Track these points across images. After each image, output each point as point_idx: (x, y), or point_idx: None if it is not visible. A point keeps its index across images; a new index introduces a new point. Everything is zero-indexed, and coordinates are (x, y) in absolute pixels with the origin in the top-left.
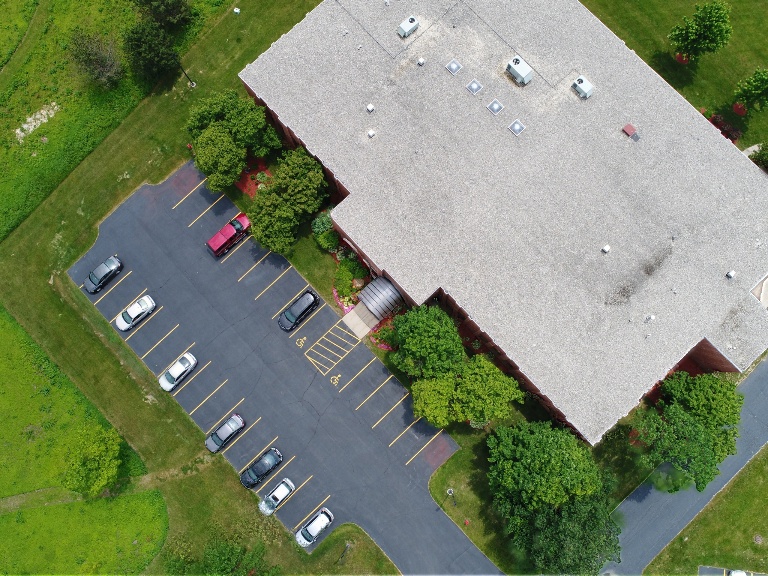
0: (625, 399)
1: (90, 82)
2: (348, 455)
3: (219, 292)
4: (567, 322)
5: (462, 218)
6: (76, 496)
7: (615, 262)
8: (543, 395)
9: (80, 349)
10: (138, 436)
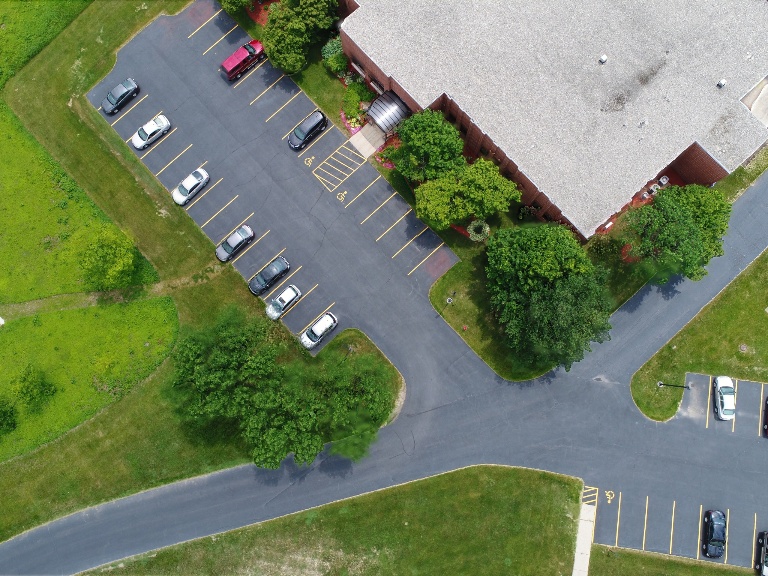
0: (618, 196)
1: None
2: (352, 266)
3: (231, 114)
4: (564, 126)
5: (466, 30)
6: (91, 302)
7: (611, 72)
8: (540, 193)
9: (97, 166)
10: (151, 247)
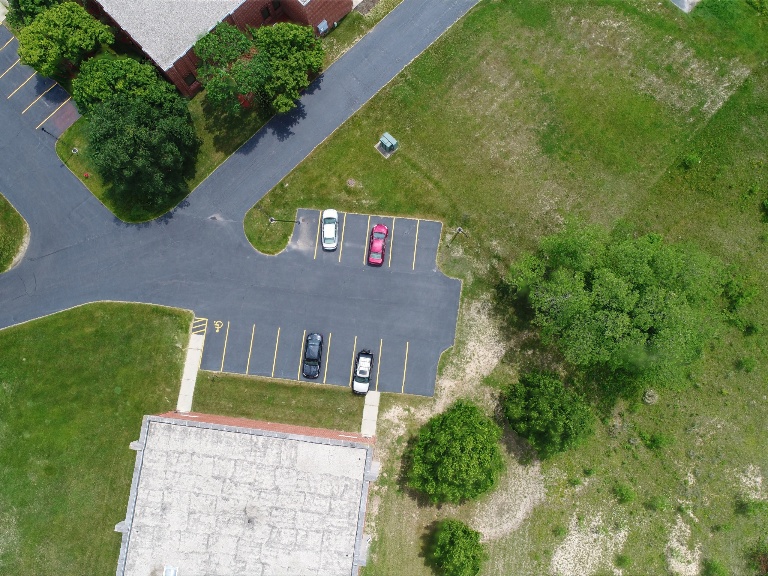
0: (196, 30)
1: None
2: None
3: None
4: None
5: None
6: None
7: None
8: (125, 31)
9: None
10: None
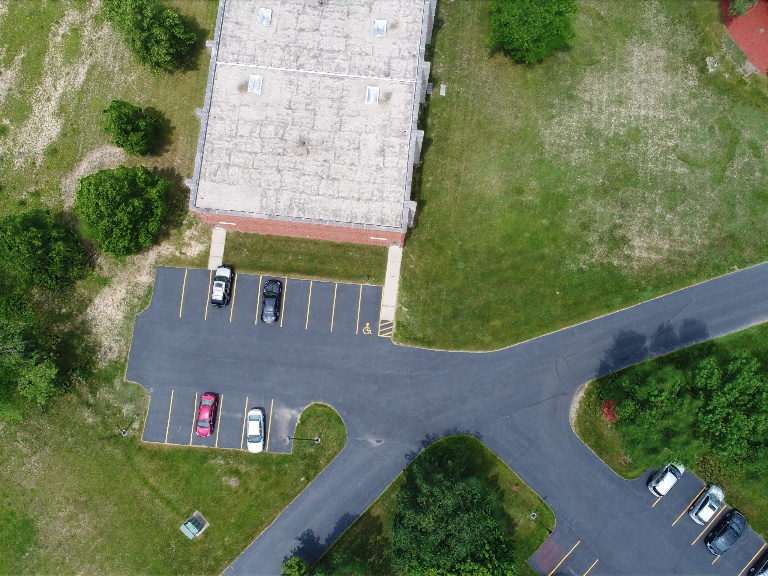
0: None
1: None
2: (639, 549)
3: None
4: None
5: None
6: None
7: None
8: None
9: None
10: None
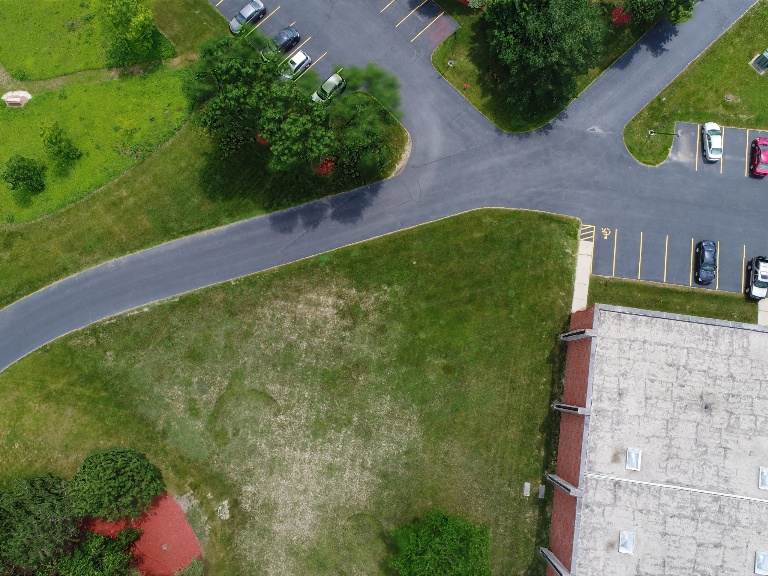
0: None
1: None
2: (359, 35)
3: None
4: None
5: None
6: (113, 77)
7: None
8: None
9: None
10: (169, 25)
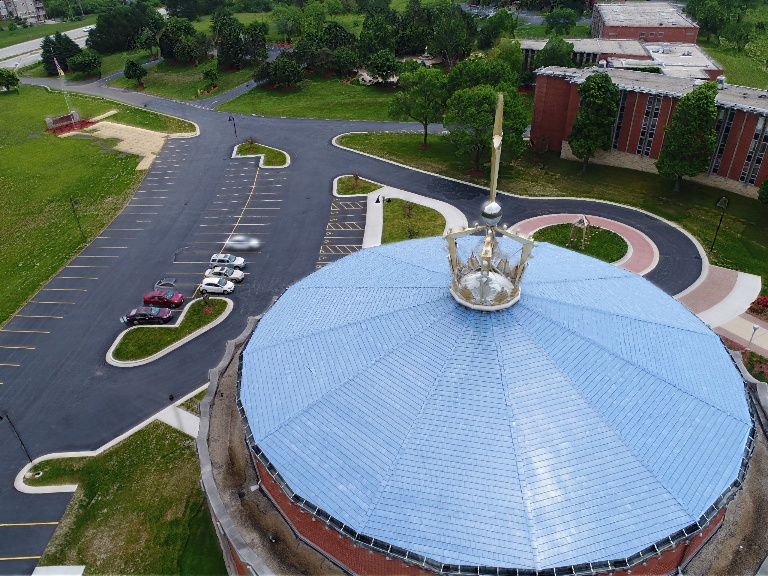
0: None
1: (433, 5)
2: None
3: None
4: None
5: None
6: None
7: None
8: None
9: None
10: None
